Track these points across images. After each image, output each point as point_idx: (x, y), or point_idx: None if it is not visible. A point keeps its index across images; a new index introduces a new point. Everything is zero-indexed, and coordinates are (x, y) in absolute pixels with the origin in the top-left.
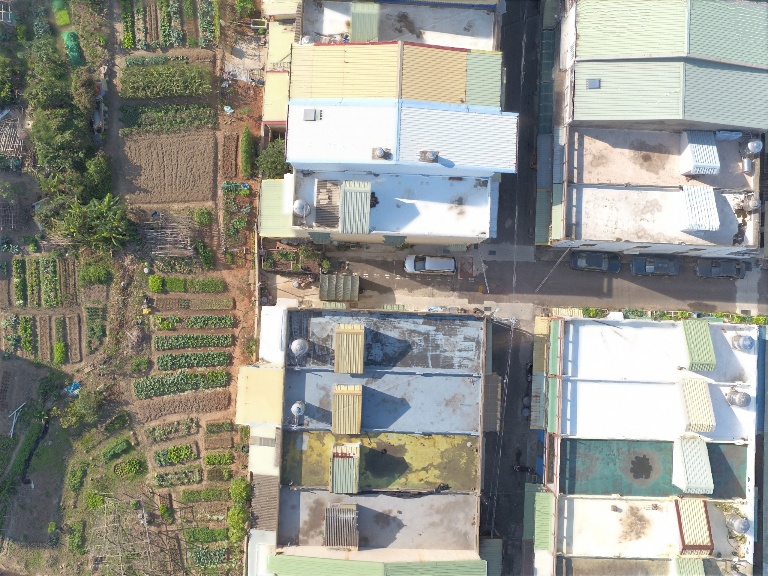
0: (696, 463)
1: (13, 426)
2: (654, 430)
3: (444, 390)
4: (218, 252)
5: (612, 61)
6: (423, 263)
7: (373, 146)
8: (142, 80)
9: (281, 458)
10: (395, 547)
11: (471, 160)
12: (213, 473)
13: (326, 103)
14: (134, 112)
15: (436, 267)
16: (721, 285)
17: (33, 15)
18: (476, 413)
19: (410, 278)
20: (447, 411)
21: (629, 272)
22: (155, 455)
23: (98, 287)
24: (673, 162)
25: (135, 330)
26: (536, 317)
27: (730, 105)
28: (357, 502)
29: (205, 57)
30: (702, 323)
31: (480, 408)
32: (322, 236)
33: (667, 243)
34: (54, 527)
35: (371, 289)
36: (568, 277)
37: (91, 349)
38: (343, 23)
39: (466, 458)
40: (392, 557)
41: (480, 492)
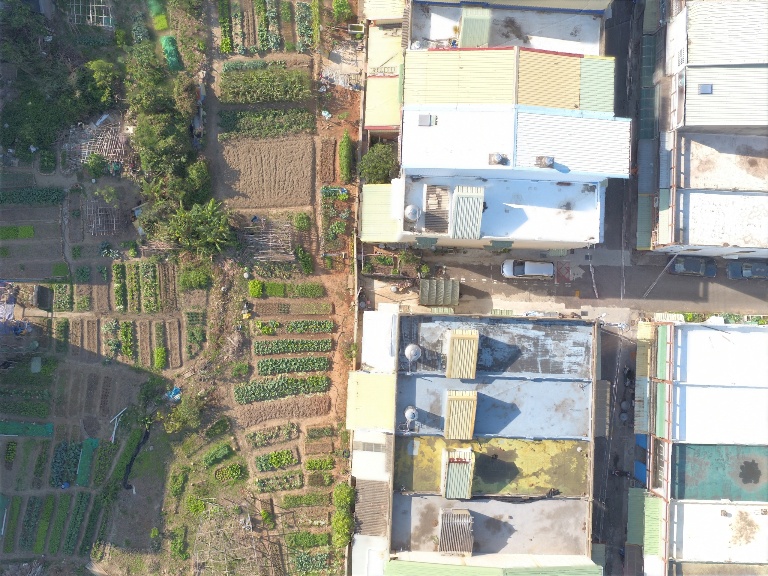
0: None
1: (114, 431)
2: (763, 435)
3: (554, 395)
4: (317, 257)
5: (724, 66)
6: (522, 268)
7: (490, 152)
8: (243, 85)
9: (393, 463)
10: (506, 552)
11: (586, 165)
12: (314, 478)
13: (441, 108)
14: (232, 117)
15: (535, 272)
16: None
17: (131, 20)
18: (586, 418)
19: (507, 283)
20: (557, 416)
21: (725, 276)
22: (256, 460)
23: (198, 292)
24: None
25: (236, 335)
26: (639, 322)
27: None
28: (468, 507)
29: (303, 62)
30: None
31: (591, 413)
32: (429, 241)
33: None
34: (157, 532)
35: (468, 294)
36: (664, 282)
37: (191, 354)
38: (450, 28)
39: (576, 463)
40: (508, 562)
41: (592, 497)
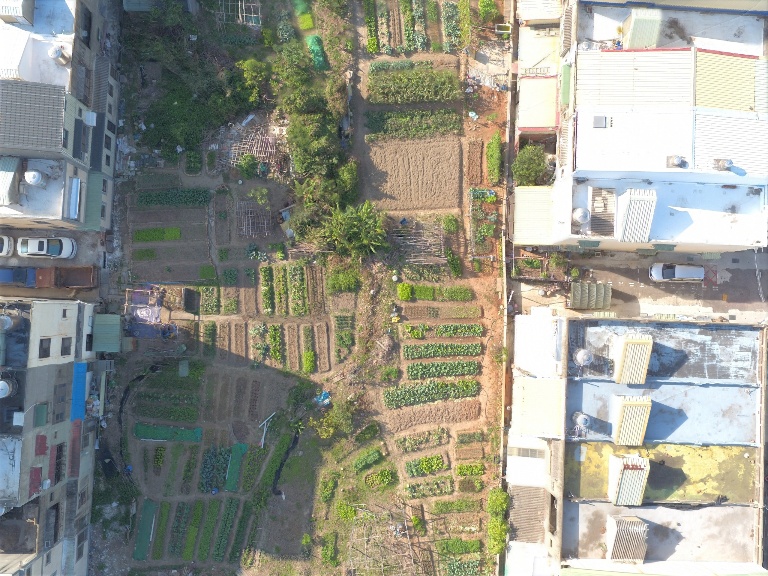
0: None
1: (264, 436)
2: None
3: (721, 401)
4: (465, 260)
5: None
6: (672, 271)
7: (668, 154)
8: (393, 85)
9: (562, 470)
10: (675, 560)
11: (761, 168)
12: (465, 484)
13: (617, 110)
14: (380, 118)
15: (686, 275)
16: None
17: (276, 19)
18: (753, 424)
19: (654, 286)
20: (724, 422)
21: None
22: (407, 466)
23: (346, 295)
24: None
25: (385, 339)
26: None
27: None
28: (636, 514)
29: (450, 62)
30: None
31: (759, 419)
32: (592, 244)
33: None
34: (309, 539)
35: (616, 297)
36: None
37: (340, 358)
38: (613, 29)
39: (744, 469)
40: (683, 570)
41: (763, 504)
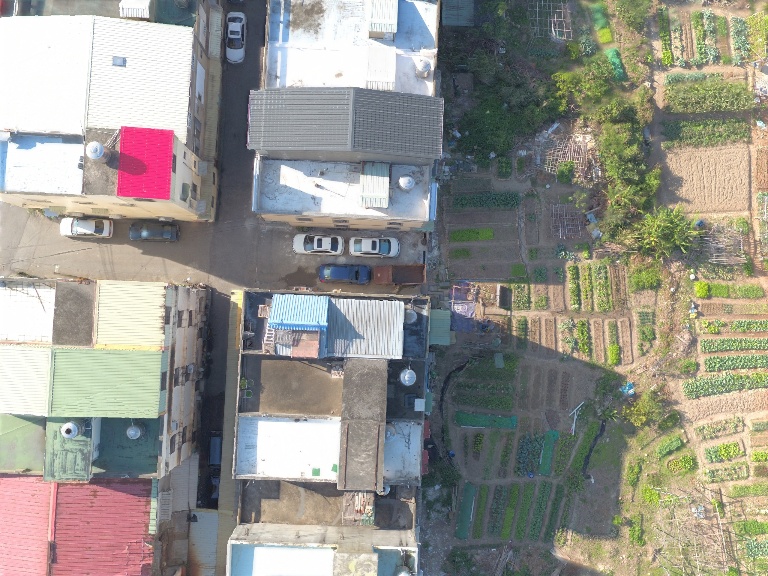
0: None
1: (574, 424)
2: None
3: None
4: (754, 260)
5: None
6: None
7: None
8: (693, 96)
9: None
10: None
11: None
12: (760, 469)
13: None
14: (675, 126)
15: None
16: None
17: (577, 33)
18: None
19: None
20: None
21: None
22: (706, 452)
23: (647, 292)
24: None
25: (685, 333)
26: None
27: None
28: None
29: (739, 74)
30: None
31: None
32: None
33: None
34: None
35: None
36: None
37: (643, 351)
38: None
39: None
40: None
41: None
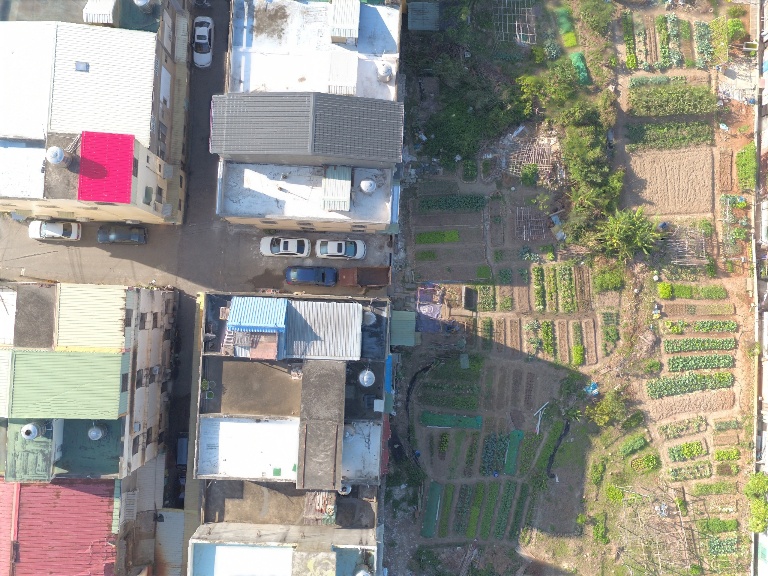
0: None
1: (539, 424)
2: None
3: None
4: (717, 261)
5: None
6: None
7: None
8: (656, 99)
9: None
10: None
11: None
12: (723, 468)
13: None
14: (639, 129)
15: None
16: None
17: (542, 37)
18: None
19: None
20: None
21: None
22: (669, 451)
23: (611, 293)
24: None
25: (649, 334)
26: None
27: None
28: None
29: (702, 77)
30: None
31: None
32: None
33: None
34: (584, 518)
35: None
36: None
37: (607, 352)
38: None
39: None
40: None
41: None
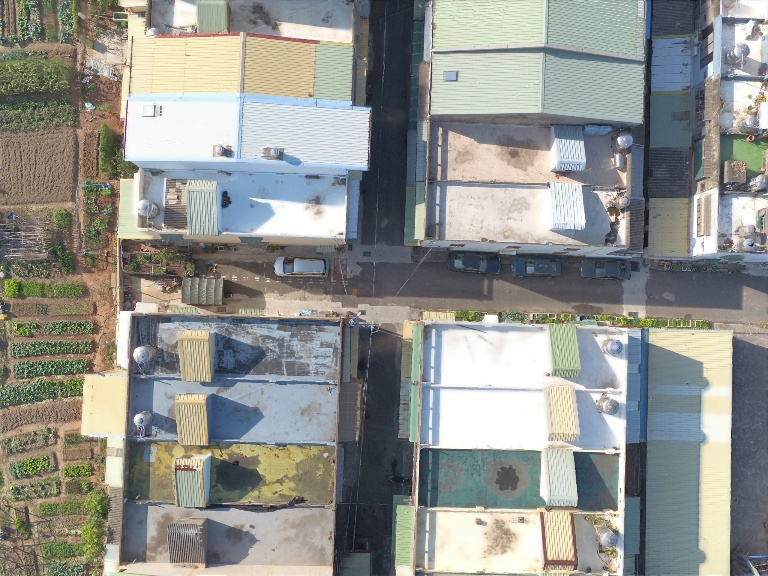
0: (561, 474)
1: None
2: (521, 439)
3: (299, 398)
4: (78, 255)
5: (470, 52)
6: (292, 265)
7: (213, 143)
8: None
9: (126, 471)
10: (247, 563)
11: (319, 157)
12: (71, 485)
13: (166, 98)
14: None
15: (305, 269)
16: (607, 286)
17: None
18: (333, 422)
19: (281, 281)
20: (302, 420)
21: (510, 273)
22: (11, 467)
23: None
24: (542, 158)
25: None
26: (404, 321)
27: (594, 98)
28: (207, 516)
29: (65, 52)
30: (569, 327)
31: (336, 417)
32: (174, 238)
33: (533, 243)
34: None
35: (240, 292)
36: (446, 279)
37: None
38: (195, 15)
39: (323, 470)
40: (238, 574)
41: (334, 505)
